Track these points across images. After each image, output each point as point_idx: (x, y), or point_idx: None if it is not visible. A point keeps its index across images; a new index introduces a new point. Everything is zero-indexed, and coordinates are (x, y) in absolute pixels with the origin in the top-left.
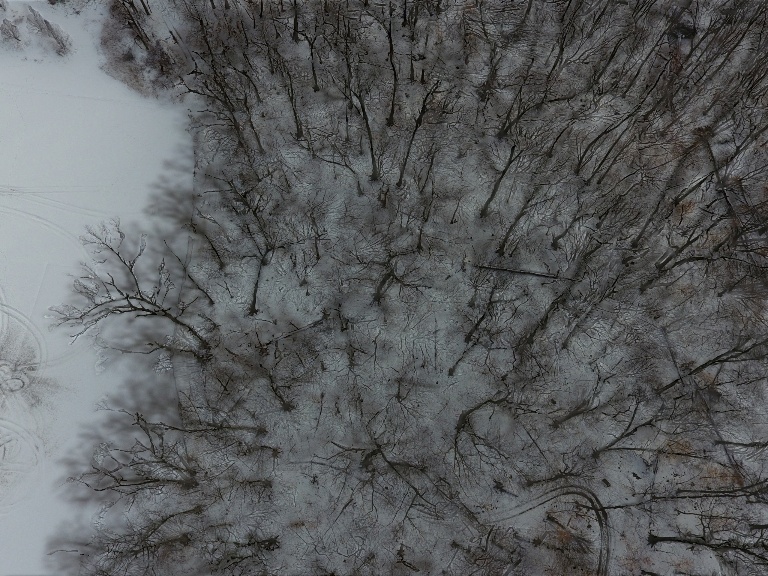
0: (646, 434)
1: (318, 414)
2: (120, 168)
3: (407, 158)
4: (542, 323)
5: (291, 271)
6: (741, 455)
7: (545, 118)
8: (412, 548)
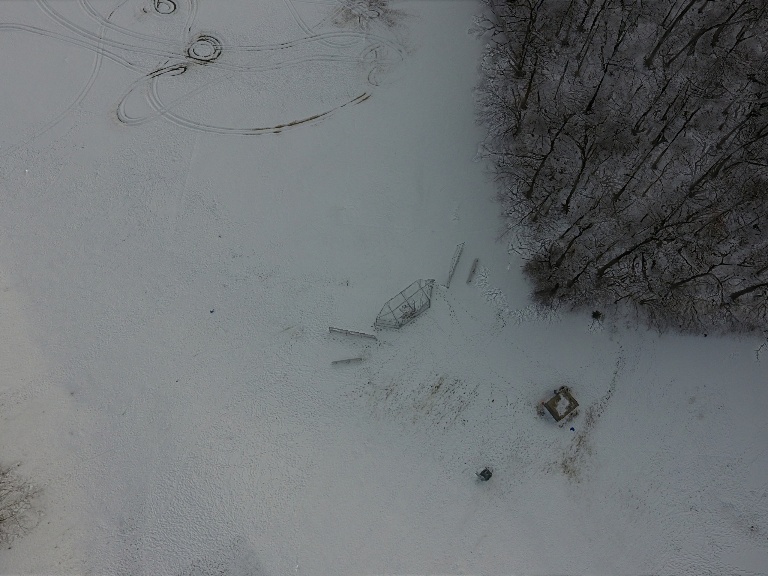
0: None
1: None
2: None
3: None
4: None
5: None
6: None
7: None
8: None
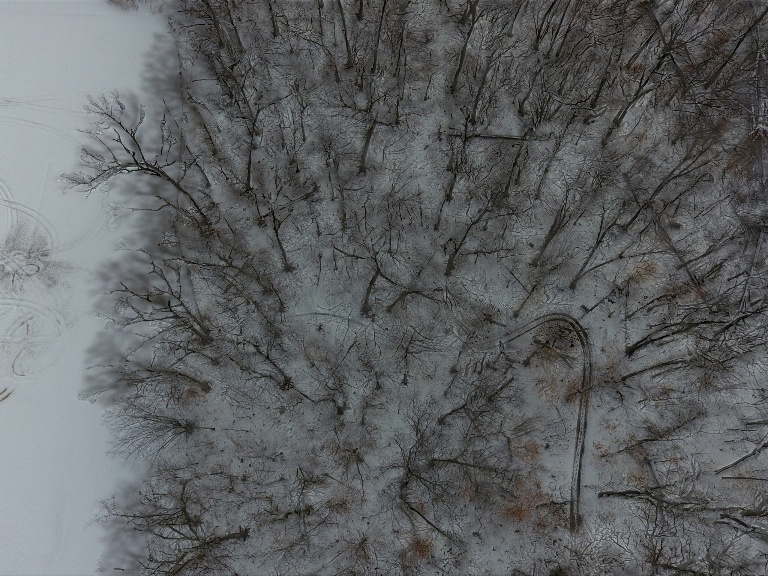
0: (617, 265)
1: (318, 272)
2: (109, 74)
3: (379, 39)
4: (516, 179)
5: (280, 152)
6: (702, 274)
7: (503, 3)
8: (415, 376)
